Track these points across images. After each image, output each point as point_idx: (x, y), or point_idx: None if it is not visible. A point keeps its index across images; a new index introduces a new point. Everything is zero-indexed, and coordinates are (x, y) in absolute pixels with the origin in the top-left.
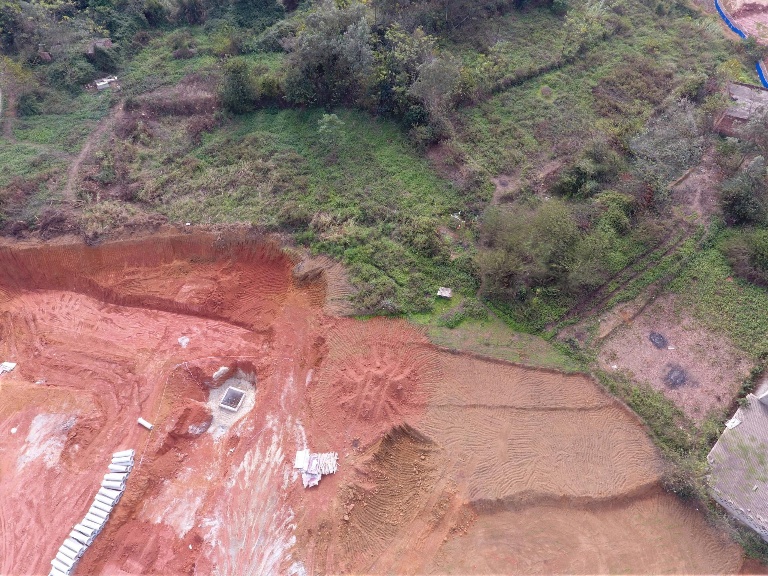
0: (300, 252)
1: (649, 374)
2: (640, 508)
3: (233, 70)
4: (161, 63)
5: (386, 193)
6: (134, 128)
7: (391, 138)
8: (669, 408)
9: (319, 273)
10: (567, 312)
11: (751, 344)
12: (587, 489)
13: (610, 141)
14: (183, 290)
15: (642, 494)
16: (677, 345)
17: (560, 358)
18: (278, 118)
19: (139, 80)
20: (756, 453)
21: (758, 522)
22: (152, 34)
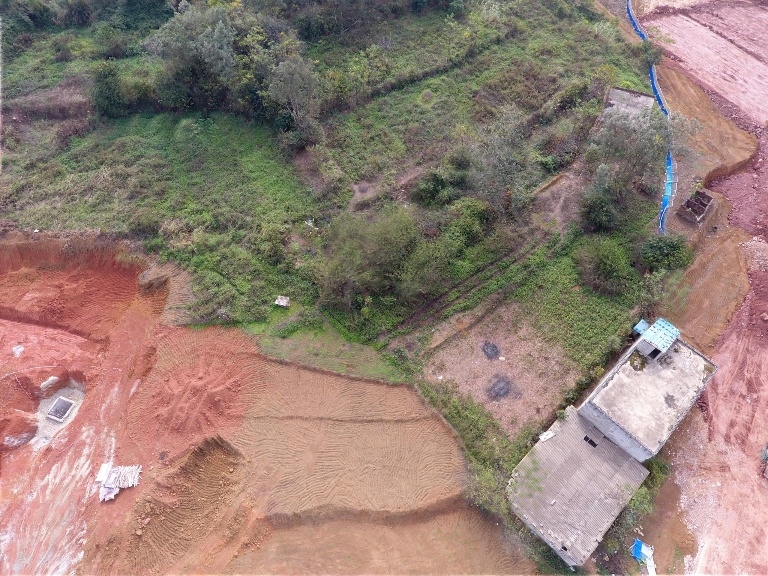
0: (149, 259)
1: (474, 385)
2: (440, 522)
3: (113, 73)
4: (40, 66)
5: (243, 199)
6: (1, 132)
7: (262, 143)
8: (485, 420)
9: (165, 281)
10: (401, 322)
11: (583, 354)
12: (386, 503)
13: (481, 147)
14: (25, 298)
15: (445, 508)
16: (509, 355)
17: (386, 369)
18: (152, 122)
19: (15, 83)
20: (562, 466)
21: (548, 537)
22: (37, 36)
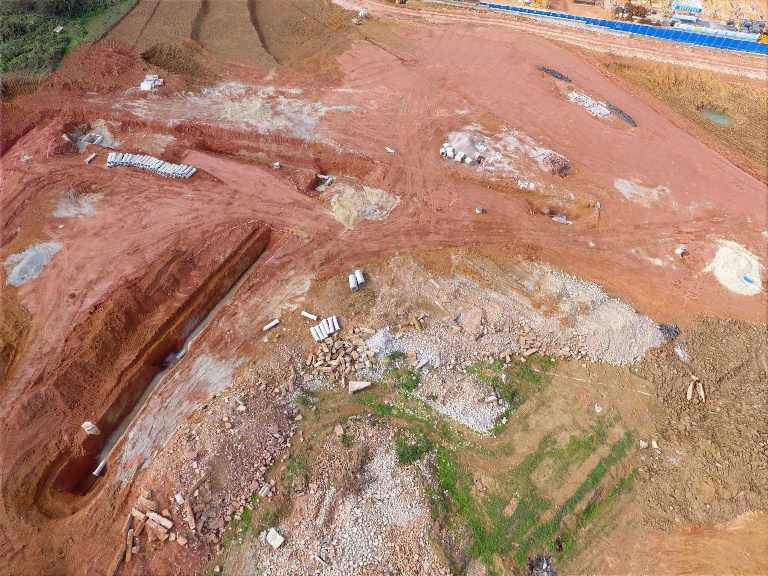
0: None
1: None
2: (210, 2)
3: None
4: None
5: None
6: None
7: None
8: None
9: (3, 86)
10: None
11: None
12: (196, 8)
13: None
14: None
15: (204, 0)
16: None
17: (127, 3)
18: None
19: None
20: None
21: None
22: None
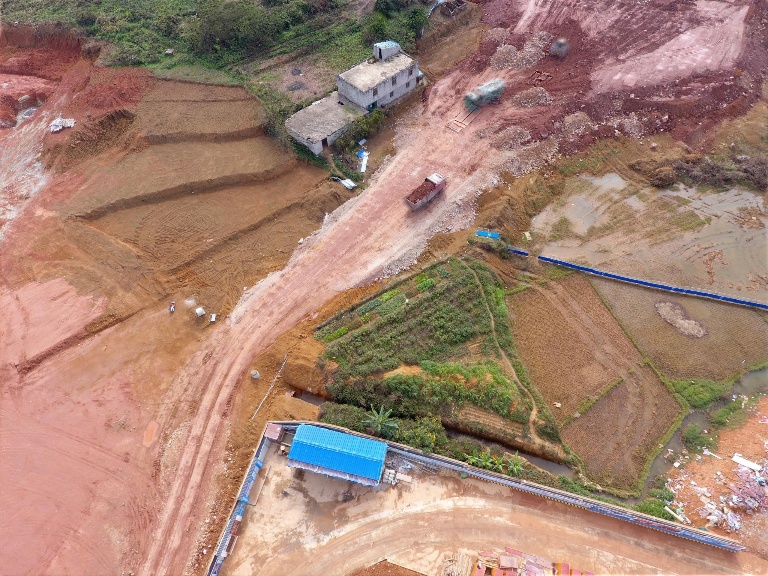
0: (89, 39)
1: (280, 85)
2: (247, 141)
3: None
4: None
5: (152, 5)
6: None
7: None
8: (282, 97)
9: (99, 49)
10: (242, 58)
11: None
12: (216, 130)
13: None
14: (9, 60)
15: (251, 135)
16: (306, 74)
17: (229, 79)
18: None
19: None
20: (320, 112)
21: (301, 135)
22: None
